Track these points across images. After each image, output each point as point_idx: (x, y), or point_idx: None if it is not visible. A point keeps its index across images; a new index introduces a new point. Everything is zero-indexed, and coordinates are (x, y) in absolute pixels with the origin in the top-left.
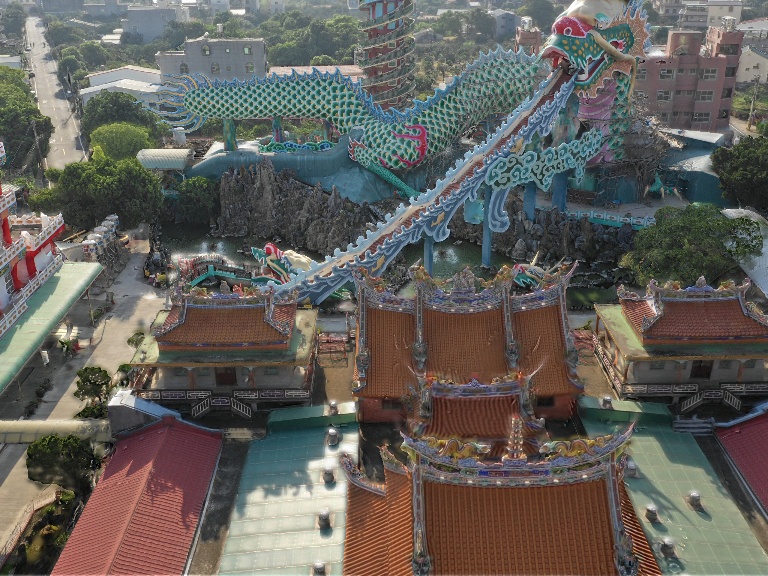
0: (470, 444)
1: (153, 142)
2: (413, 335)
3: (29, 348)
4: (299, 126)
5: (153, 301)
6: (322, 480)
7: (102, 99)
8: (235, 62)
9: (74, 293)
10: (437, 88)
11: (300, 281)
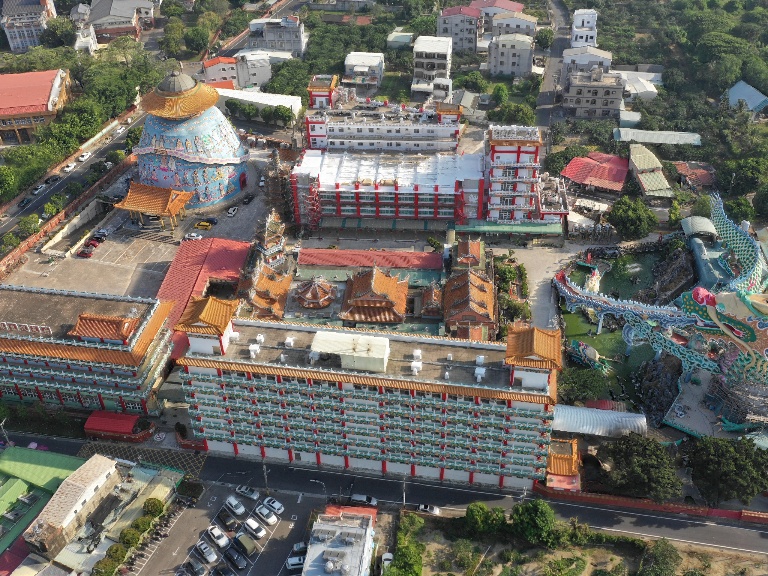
0: None
1: (746, 220)
2: None
3: (494, 230)
4: None
5: (565, 256)
6: None
7: None
8: None
9: (535, 231)
10: None
11: None
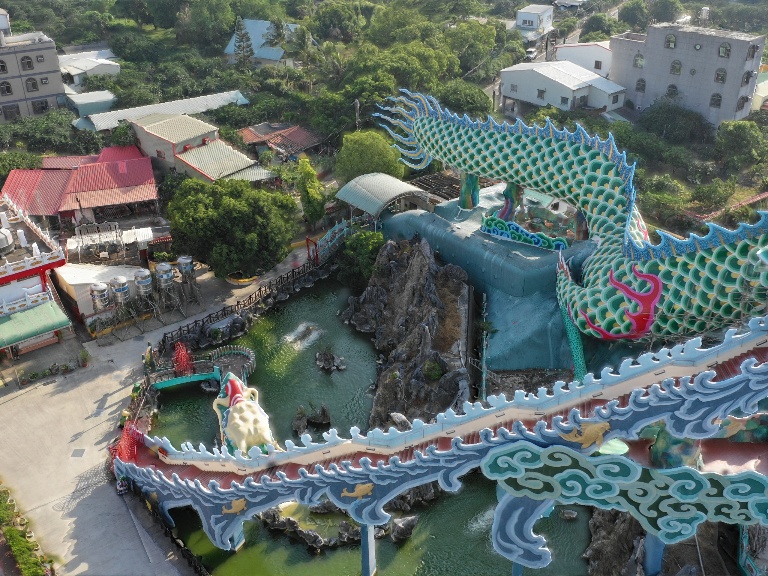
0: None
1: None
2: None
3: None
4: (731, 178)
5: (107, 384)
6: None
7: (441, 90)
8: (703, 64)
9: None
10: None
11: (188, 459)
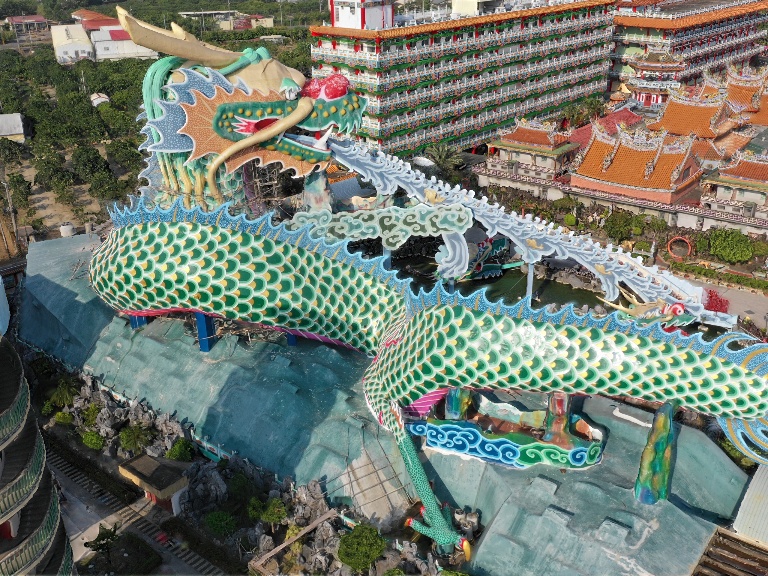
0: None
1: None
2: None
3: None
4: None
5: None
6: None
7: None
8: None
9: None
10: (345, 240)
11: None
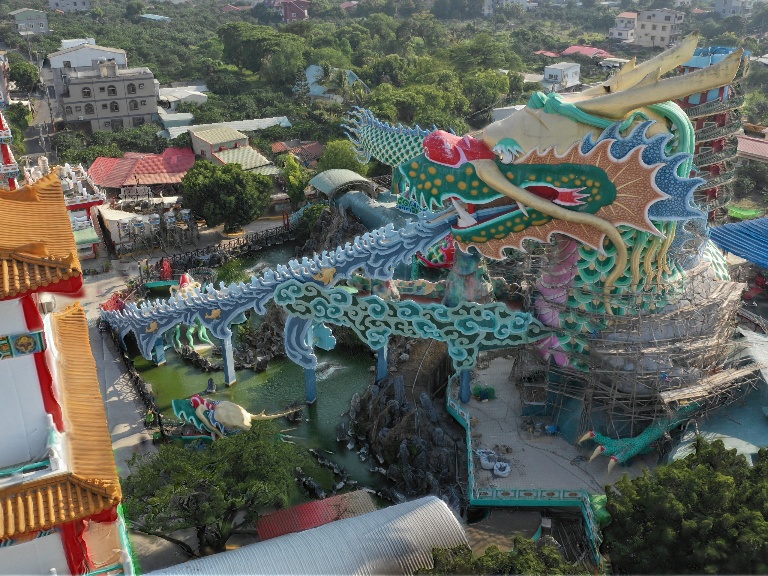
0: None
1: None
2: None
3: None
4: None
5: (117, 281)
6: None
7: None
8: None
9: None
10: None
11: None
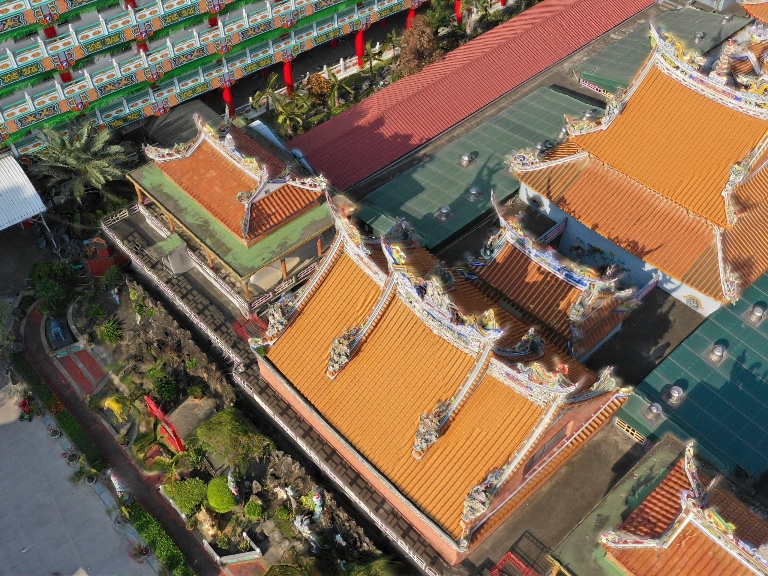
0: (753, 81)
1: None
2: (514, 367)
3: None
4: None
5: None
6: (725, 357)
7: None
8: None
9: None
10: None
11: None
